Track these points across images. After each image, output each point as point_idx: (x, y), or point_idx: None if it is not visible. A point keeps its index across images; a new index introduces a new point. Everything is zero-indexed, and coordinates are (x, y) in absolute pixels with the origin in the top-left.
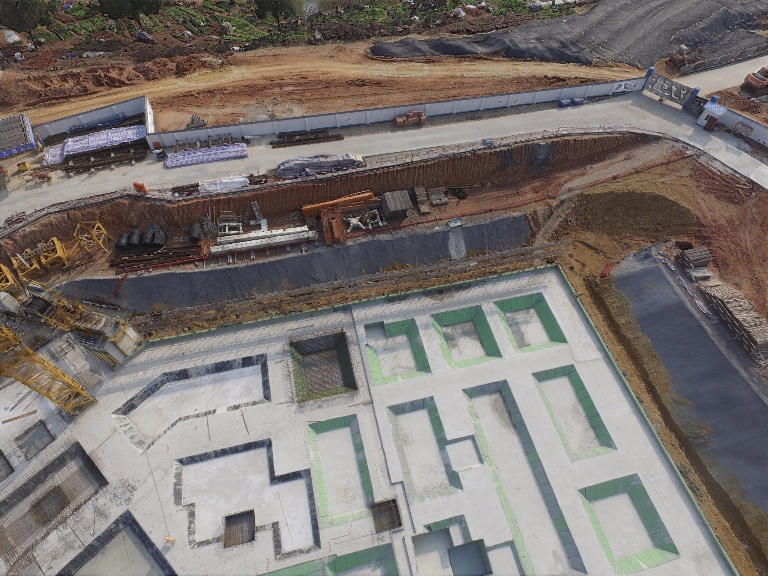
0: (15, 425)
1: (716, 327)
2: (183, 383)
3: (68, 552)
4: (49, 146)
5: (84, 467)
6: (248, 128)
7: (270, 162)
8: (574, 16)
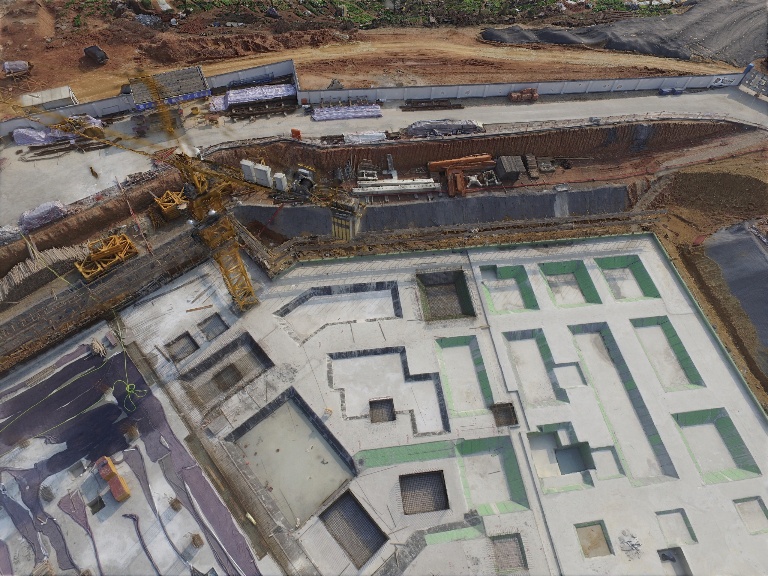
0: (197, 314)
1: None
2: (327, 298)
3: (248, 411)
4: (213, 96)
5: (252, 352)
6: (382, 92)
7: (401, 122)
8: (672, 15)
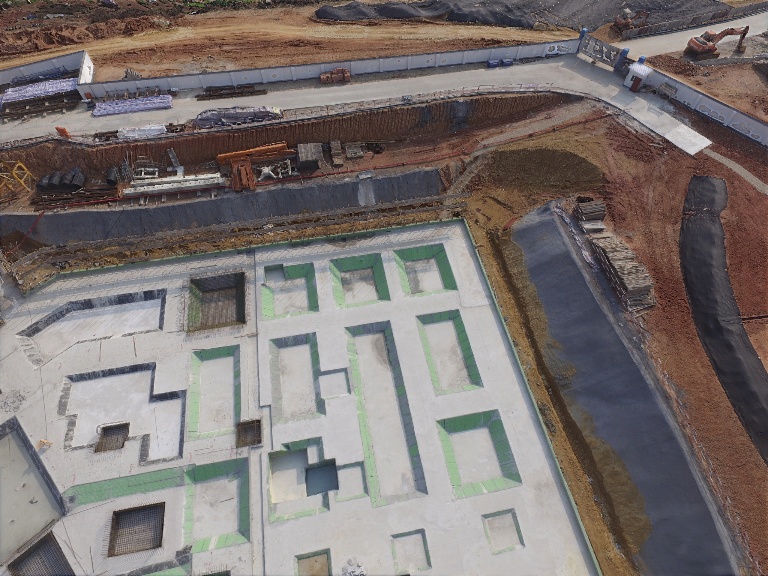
0: None
1: (596, 275)
2: (87, 312)
3: None
4: None
5: None
6: (175, 81)
7: (191, 113)
8: None
